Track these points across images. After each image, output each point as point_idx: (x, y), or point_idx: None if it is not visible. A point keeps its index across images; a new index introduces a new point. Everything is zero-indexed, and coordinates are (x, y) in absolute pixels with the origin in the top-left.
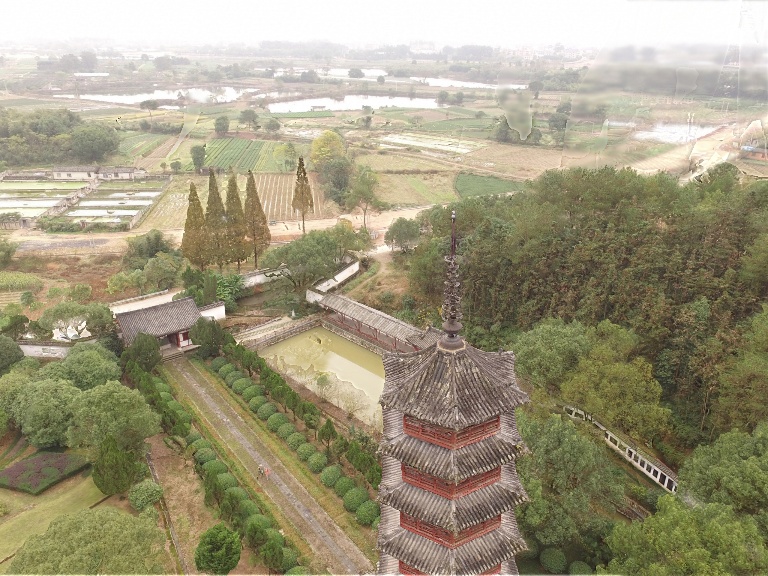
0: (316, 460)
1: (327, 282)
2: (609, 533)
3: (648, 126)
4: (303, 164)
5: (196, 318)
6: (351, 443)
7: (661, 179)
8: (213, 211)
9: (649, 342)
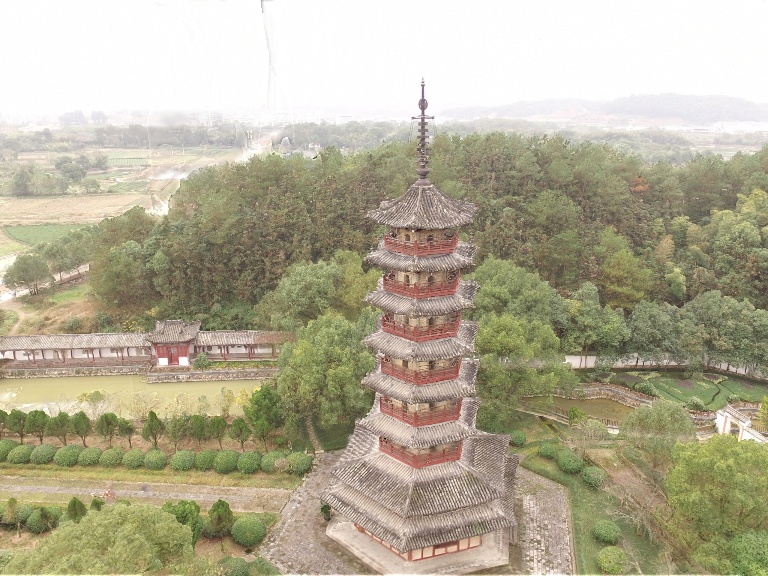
0: (156, 456)
1: None
2: None
3: (219, 144)
4: None
5: None
6: (195, 417)
7: None
8: None
9: None
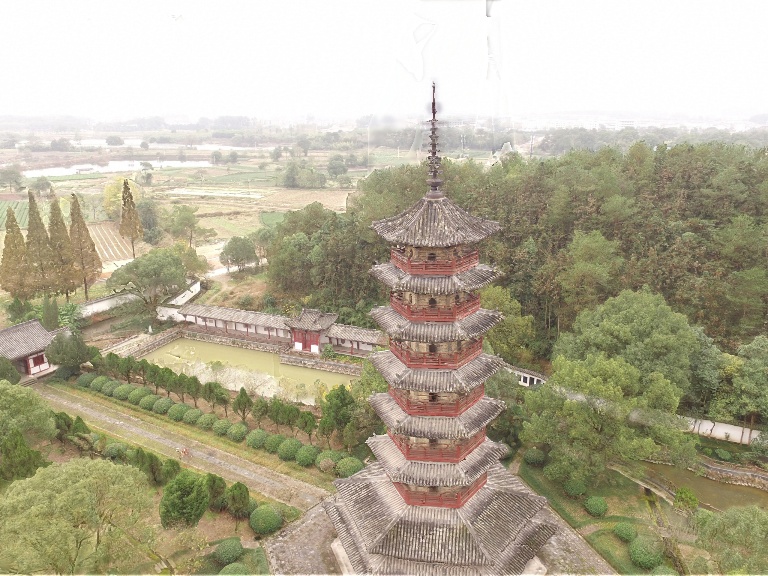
0: (237, 429)
1: (175, 300)
2: (516, 412)
3: None
4: (128, 188)
5: (47, 339)
6: (273, 401)
7: (471, 165)
8: (36, 238)
9: (497, 280)
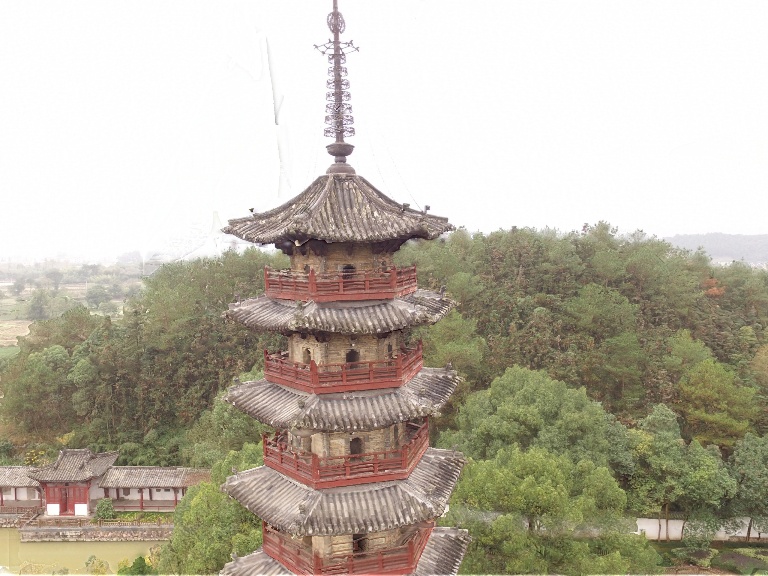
0: None
1: None
2: None
3: None
4: None
5: None
6: None
7: None
8: None
9: None
